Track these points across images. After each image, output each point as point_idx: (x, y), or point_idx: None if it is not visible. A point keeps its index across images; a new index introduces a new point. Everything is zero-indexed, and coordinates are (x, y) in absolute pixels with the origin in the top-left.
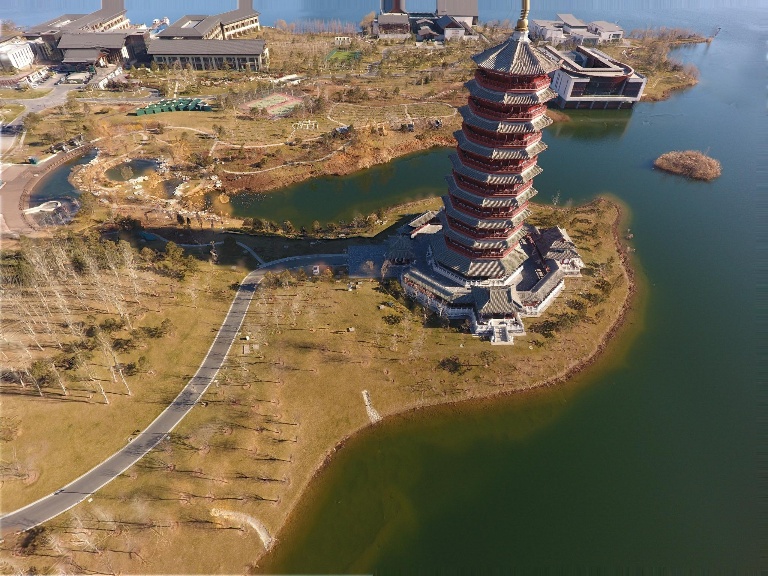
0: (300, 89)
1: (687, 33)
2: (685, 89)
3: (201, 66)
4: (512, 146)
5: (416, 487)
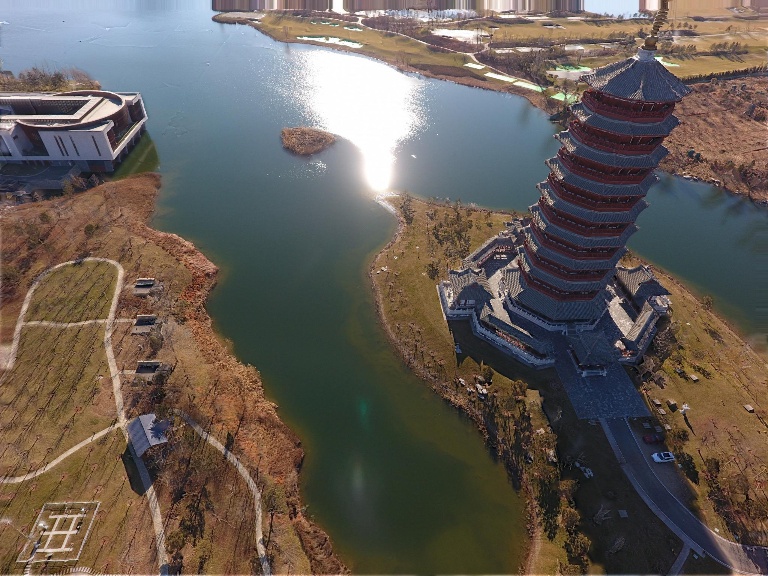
0: None
1: None
2: None
3: None
4: None
5: None
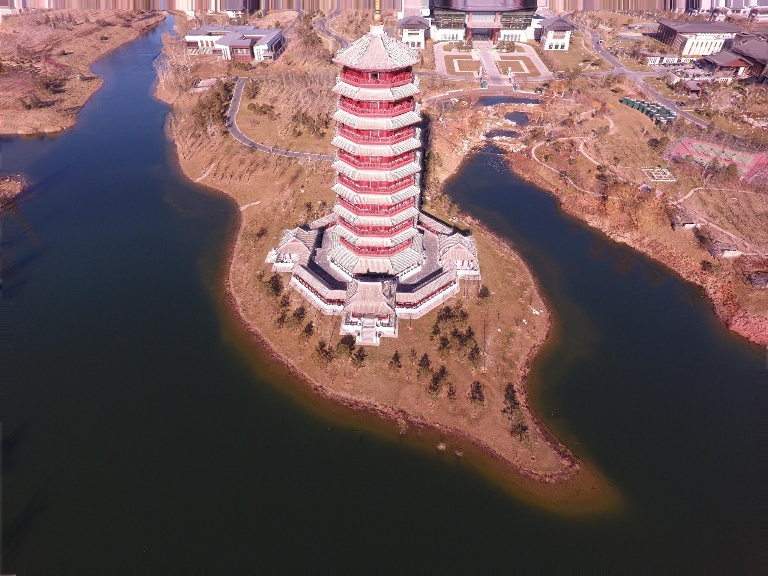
0: None
1: None
2: None
3: None
4: None
5: (197, 222)
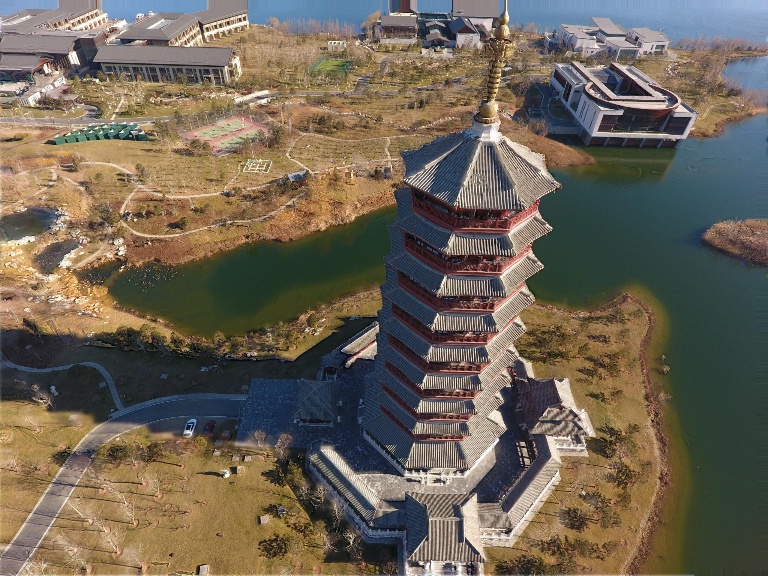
0: (266, 111)
1: (746, 44)
2: (743, 119)
3: (157, 77)
4: (468, 310)
5: None
